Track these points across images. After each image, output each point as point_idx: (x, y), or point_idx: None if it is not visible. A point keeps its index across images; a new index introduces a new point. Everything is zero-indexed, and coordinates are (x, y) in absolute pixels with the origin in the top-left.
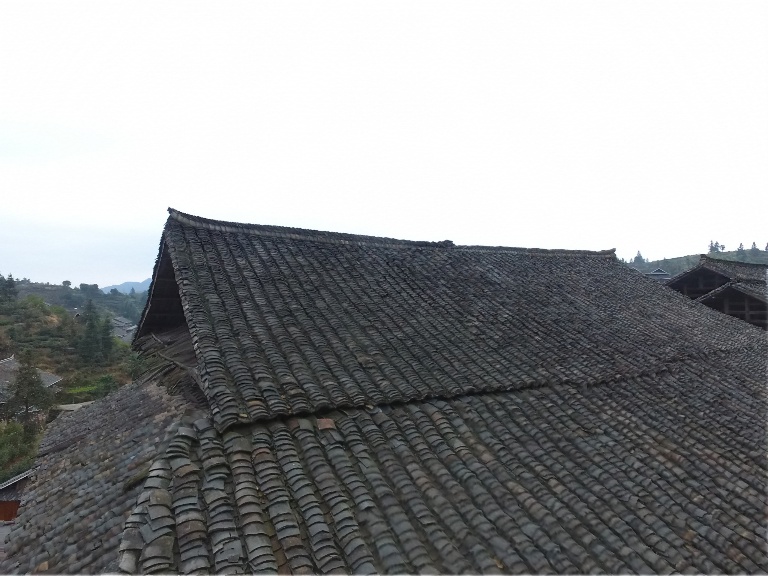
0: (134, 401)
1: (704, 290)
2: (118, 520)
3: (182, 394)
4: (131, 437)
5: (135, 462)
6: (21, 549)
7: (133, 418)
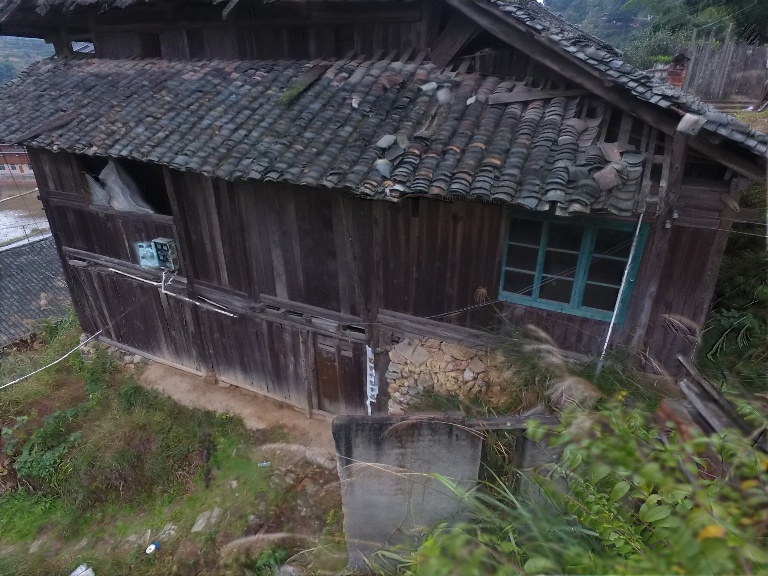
0: (93, 80)
1: None
2: (329, 113)
3: None
4: (186, 91)
5: (249, 95)
6: (221, 160)
7: (139, 86)
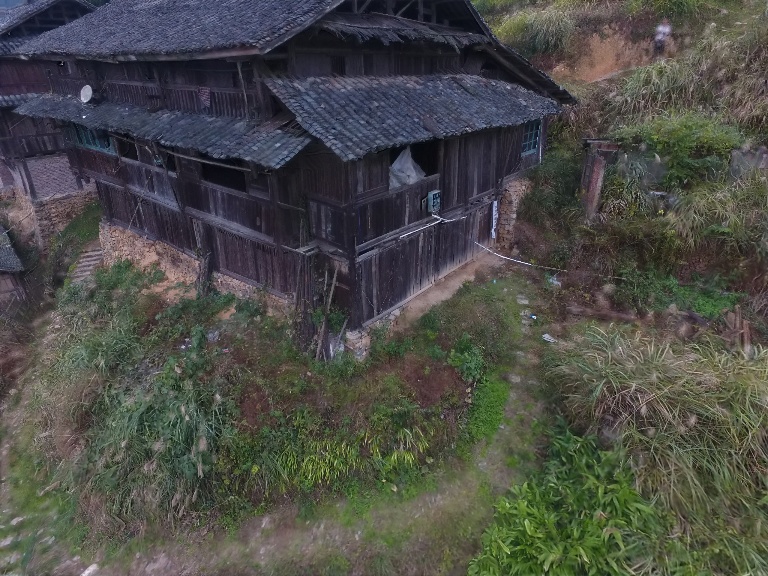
0: (373, 94)
1: (55, 21)
2: None
3: (382, 77)
4: None
5: None
6: None
7: None
